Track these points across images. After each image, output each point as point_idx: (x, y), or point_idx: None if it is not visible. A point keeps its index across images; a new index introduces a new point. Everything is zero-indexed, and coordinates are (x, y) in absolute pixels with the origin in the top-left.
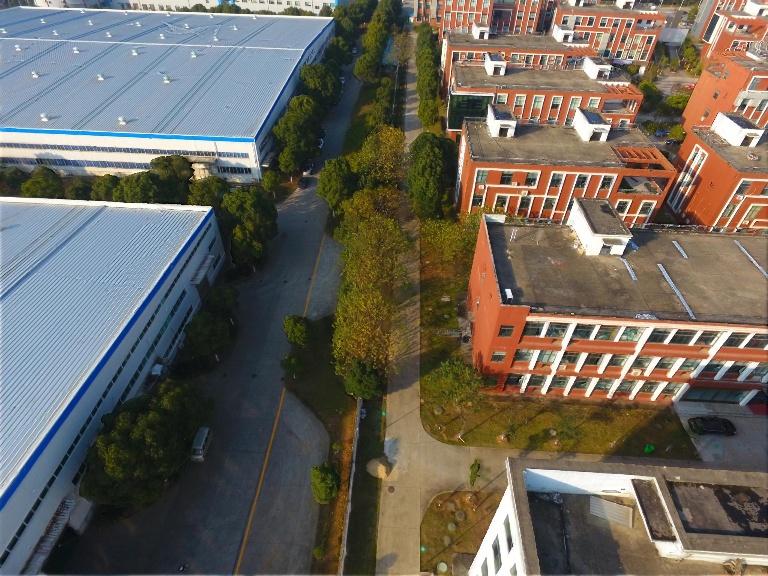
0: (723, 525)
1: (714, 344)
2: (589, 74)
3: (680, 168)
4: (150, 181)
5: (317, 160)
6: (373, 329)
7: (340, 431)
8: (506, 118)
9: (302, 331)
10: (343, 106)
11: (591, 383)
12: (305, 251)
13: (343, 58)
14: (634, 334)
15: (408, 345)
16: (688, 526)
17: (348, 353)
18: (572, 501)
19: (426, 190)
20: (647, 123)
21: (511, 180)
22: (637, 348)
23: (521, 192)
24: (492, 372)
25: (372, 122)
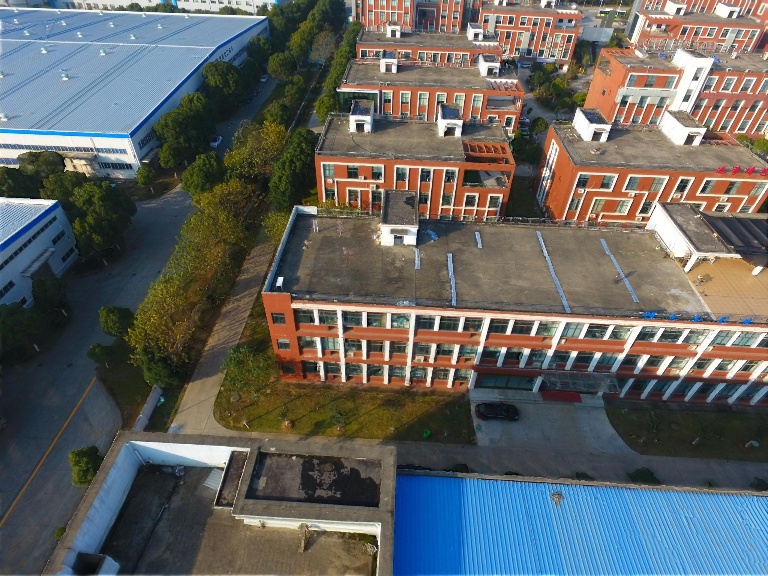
0: (289, 492)
1: (482, 331)
2: (481, 71)
3: (544, 163)
4: (5, 176)
5: None
6: (161, 318)
7: (133, 418)
8: (363, 113)
9: (114, 321)
10: (256, 104)
11: (384, 370)
12: (164, 245)
13: (265, 56)
14: (406, 321)
15: (229, 335)
16: (254, 493)
17: (137, 341)
18: (193, 473)
19: (279, 184)
20: (537, 120)
21: (358, 174)
22: (410, 335)
23: (369, 186)
24: (285, 360)
25: (270, 119)
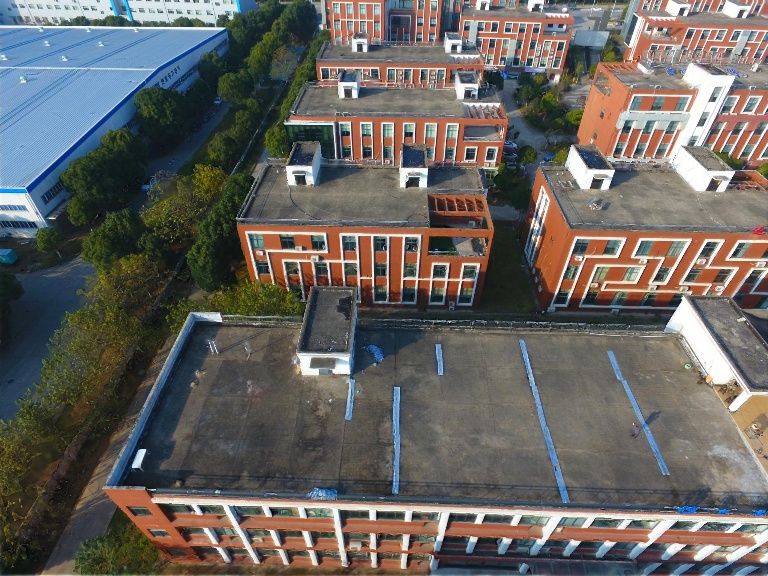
0: None
1: (439, 520)
2: (457, 93)
3: (532, 212)
4: None
5: (138, 204)
6: None
7: None
8: (304, 162)
9: None
10: (205, 132)
11: None
12: None
13: (219, 75)
14: None
15: None
16: None
17: None
18: None
19: (197, 257)
20: (525, 149)
21: (294, 244)
22: (335, 525)
23: (310, 258)
24: (168, 545)
25: (213, 155)
